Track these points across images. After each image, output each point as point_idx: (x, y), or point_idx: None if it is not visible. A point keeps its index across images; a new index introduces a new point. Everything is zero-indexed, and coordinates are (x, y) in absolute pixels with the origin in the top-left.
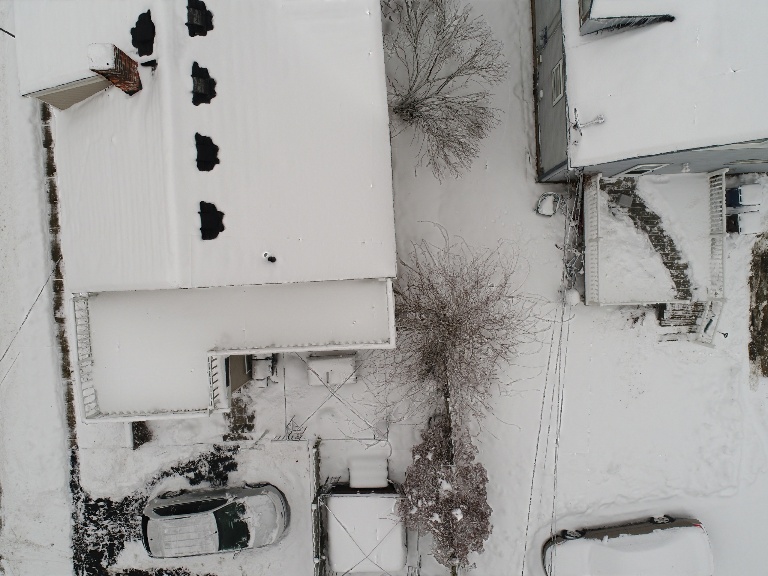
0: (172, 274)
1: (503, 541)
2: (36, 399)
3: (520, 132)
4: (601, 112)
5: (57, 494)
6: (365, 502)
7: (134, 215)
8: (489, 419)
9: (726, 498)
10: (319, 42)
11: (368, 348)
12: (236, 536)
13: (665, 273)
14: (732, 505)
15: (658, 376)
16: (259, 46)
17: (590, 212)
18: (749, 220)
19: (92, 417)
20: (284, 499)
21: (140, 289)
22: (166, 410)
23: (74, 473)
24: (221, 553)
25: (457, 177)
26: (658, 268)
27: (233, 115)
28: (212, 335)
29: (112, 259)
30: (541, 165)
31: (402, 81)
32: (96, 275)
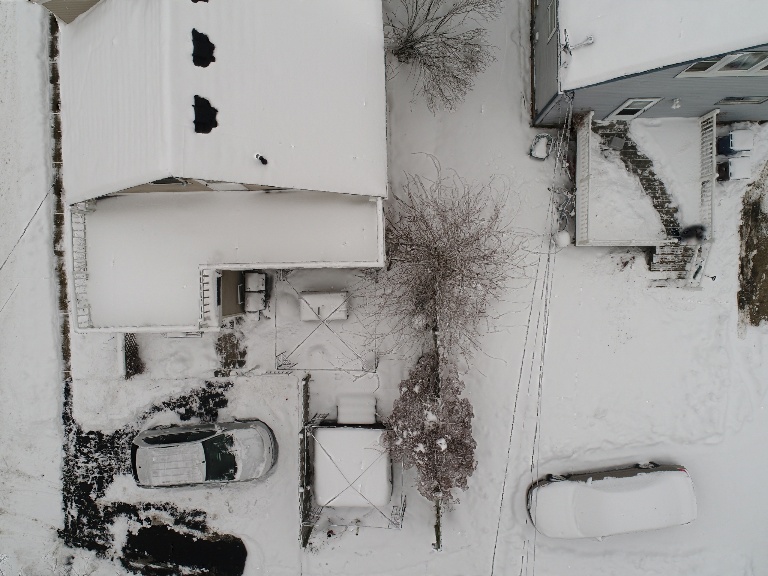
0: (164, 162)
1: (488, 483)
2: (33, 329)
3: (516, 77)
4: (591, 33)
5: (49, 425)
6: (352, 436)
7: (131, 112)
8: (478, 361)
9: (712, 446)
10: None
11: (357, 266)
12: (223, 468)
13: (655, 216)
14: (718, 453)
15: (647, 322)
16: None
17: (582, 153)
18: (739, 165)
19: None
20: (272, 436)
21: (134, 185)
22: None
23: (67, 405)
24: (208, 488)
25: (451, 109)
26: (648, 210)
27: (230, 17)
28: (205, 253)
29: (108, 160)
30: (535, 107)
31: None
32: (93, 179)
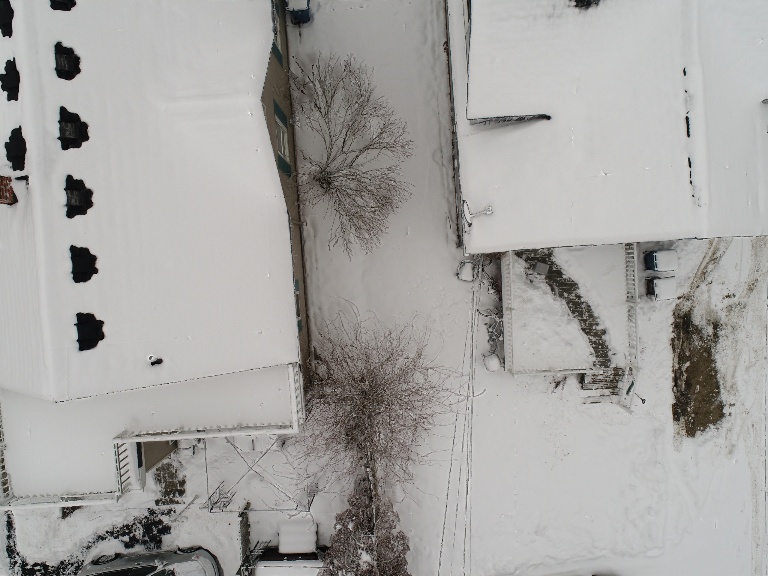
0: (47, 388)
1: None
2: None
3: (440, 198)
4: (490, 203)
5: None
6: (291, 570)
7: (18, 322)
8: (417, 482)
9: (653, 558)
10: (206, 140)
11: (271, 433)
12: None
13: (583, 339)
14: (659, 565)
15: (583, 438)
16: (140, 150)
17: (506, 280)
18: (664, 286)
19: (4, 503)
20: (216, 563)
21: None
22: (78, 493)
23: (10, 538)
24: None
25: (366, 254)
26: (575, 335)
27: (112, 223)
28: (121, 419)
29: (3, 361)
30: (459, 232)
31: (320, 150)
32: None
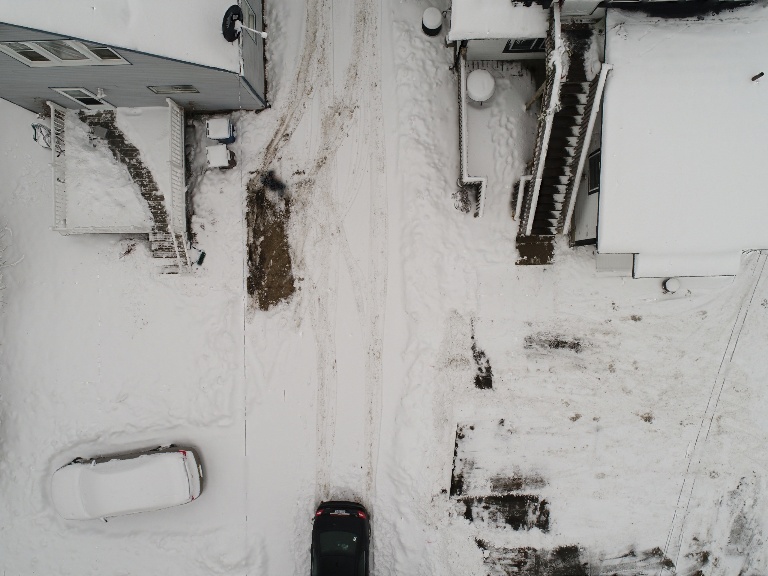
0: None
1: (18, 467)
2: None
3: None
4: None
5: None
6: None
7: None
8: (7, 348)
9: (225, 428)
10: None
11: None
12: None
13: (140, 203)
14: (232, 435)
15: (161, 308)
16: None
17: None
18: (214, 153)
19: None
20: None
21: None
22: None
23: None
24: None
25: None
26: (131, 198)
27: None
28: None
29: None
30: None
31: None
32: None
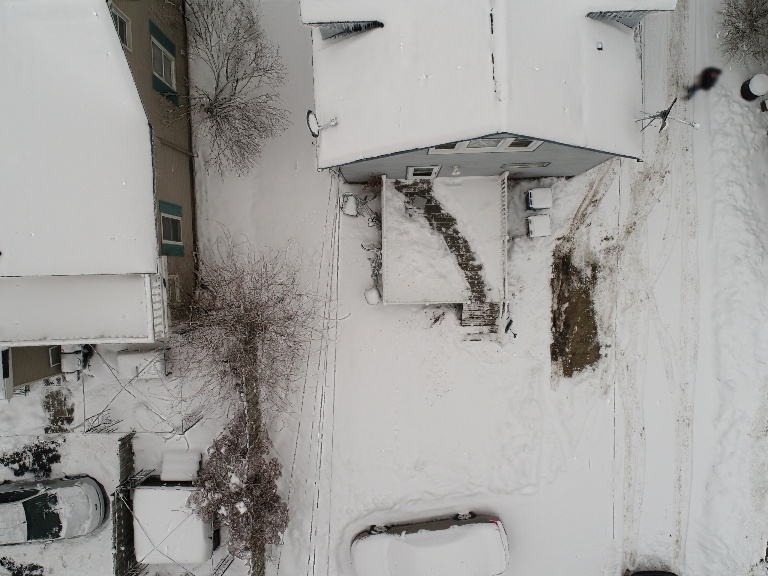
0: None
1: (312, 535)
2: None
3: None
4: (336, 115)
5: None
6: (168, 495)
7: None
8: None
9: (527, 496)
10: (57, 42)
11: (127, 342)
12: (49, 526)
13: (458, 274)
14: (534, 503)
15: (462, 375)
16: None
17: None
18: (538, 223)
19: None
20: (102, 491)
21: None
22: None
23: None
24: (42, 543)
25: (238, 176)
26: (451, 269)
27: None
28: None
29: None
30: None
31: (210, 81)
32: None
